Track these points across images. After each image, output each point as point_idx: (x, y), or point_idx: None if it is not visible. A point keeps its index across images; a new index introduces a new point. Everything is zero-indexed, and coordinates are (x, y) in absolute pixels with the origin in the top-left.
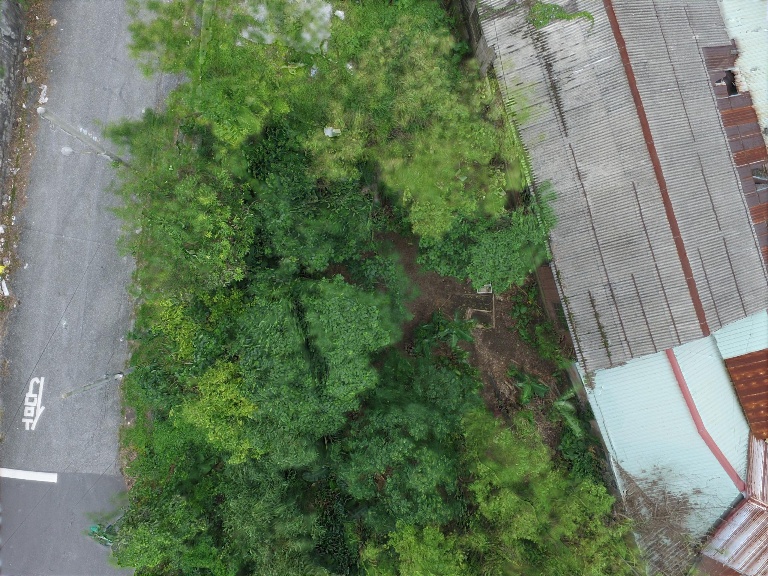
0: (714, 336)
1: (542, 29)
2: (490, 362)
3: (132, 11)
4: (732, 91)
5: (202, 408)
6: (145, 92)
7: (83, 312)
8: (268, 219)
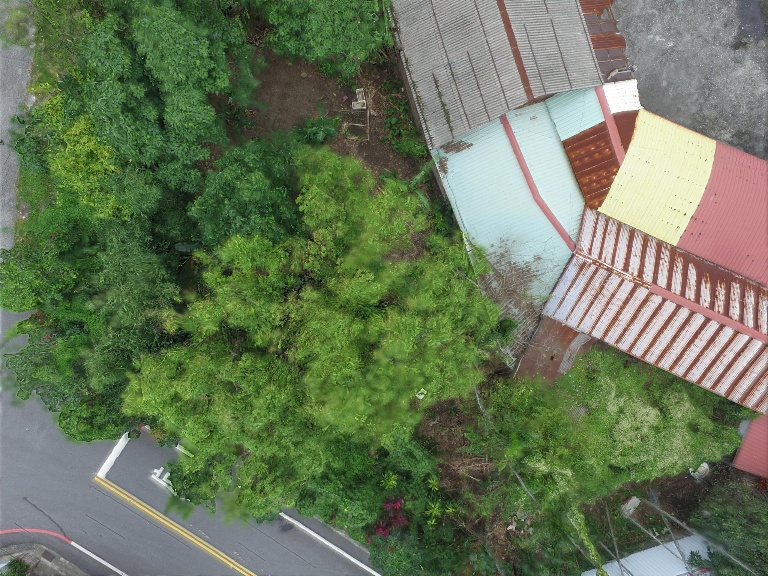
0: (553, 121)
1: None
2: (364, 170)
3: None
4: None
5: (68, 159)
6: None
7: None
8: None
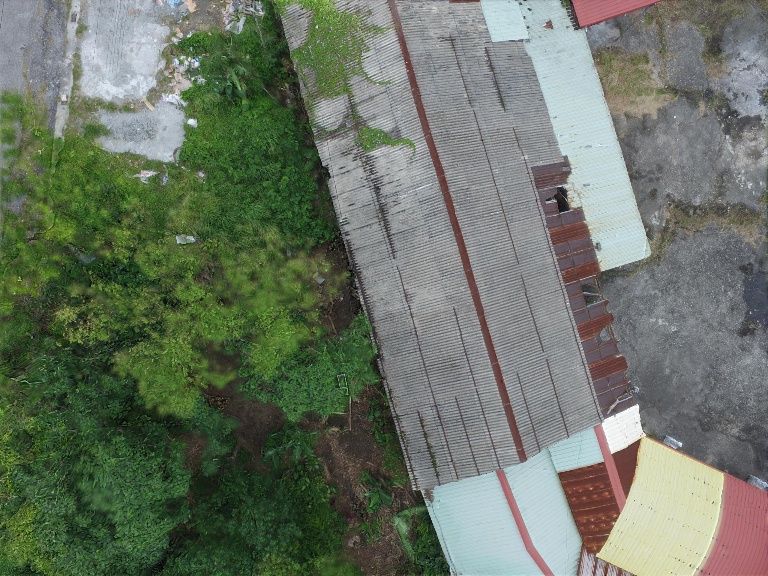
0: (548, 449)
1: (370, 153)
2: (346, 465)
3: None
4: (564, 207)
5: (11, 548)
6: None
7: None
8: (116, 330)
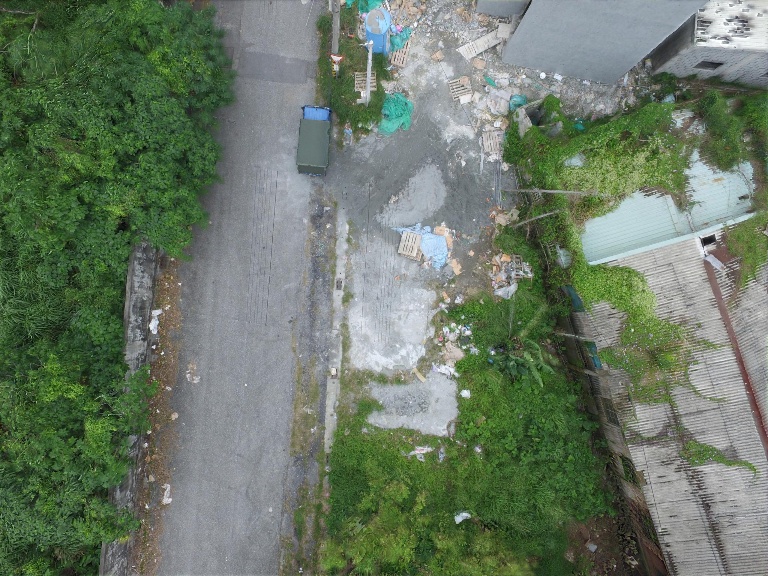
0: None
1: (697, 467)
2: None
3: (255, 402)
4: None
5: None
6: (272, 489)
7: None
8: None
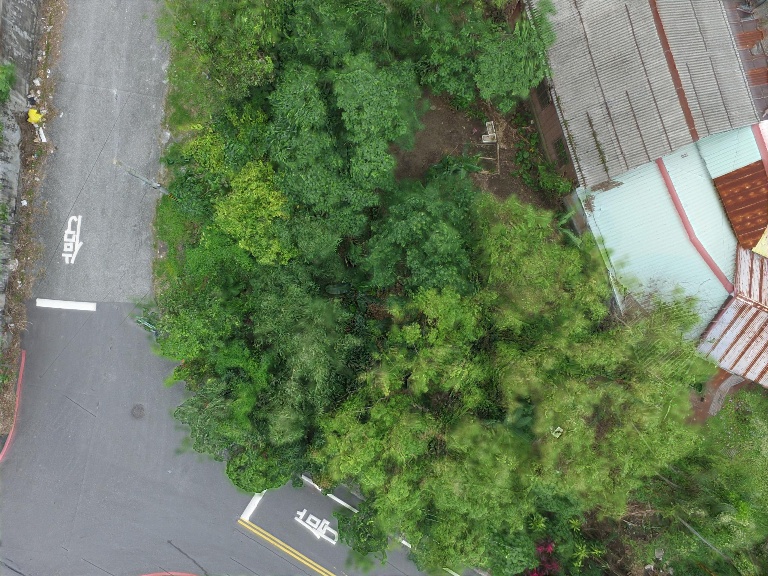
0: (703, 158)
1: None
2: (496, 205)
3: None
4: None
5: (235, 206)
6: None
7: (116, 156)
8: (286, 68)
